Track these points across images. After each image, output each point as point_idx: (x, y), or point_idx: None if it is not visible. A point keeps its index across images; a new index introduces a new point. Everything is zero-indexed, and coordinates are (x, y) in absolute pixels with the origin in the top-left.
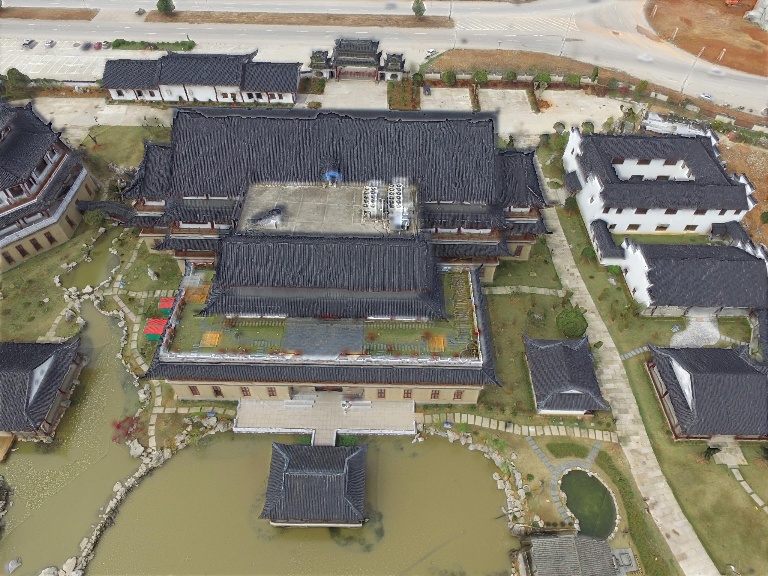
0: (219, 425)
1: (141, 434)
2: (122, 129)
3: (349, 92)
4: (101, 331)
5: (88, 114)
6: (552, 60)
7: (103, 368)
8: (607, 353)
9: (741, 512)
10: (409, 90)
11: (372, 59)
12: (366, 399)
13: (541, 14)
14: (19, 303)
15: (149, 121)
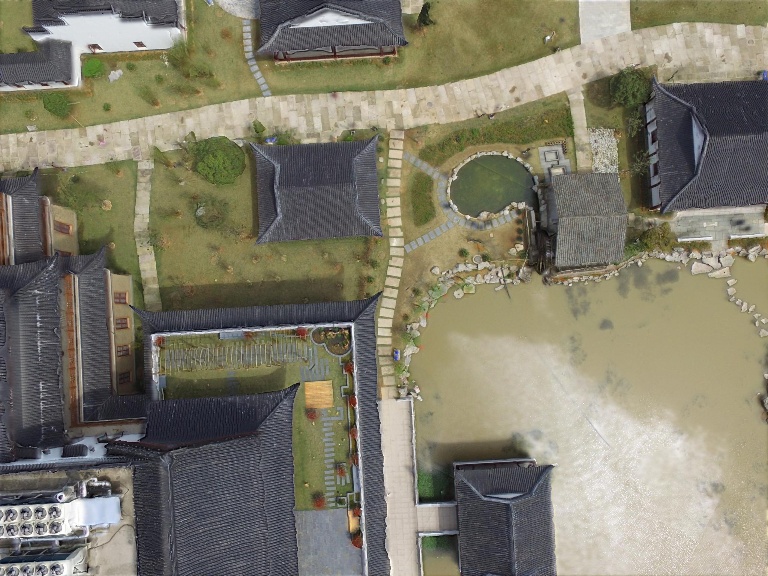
0: None
1: None
2: None
3: None
4: None
5: None
6: None
7: None
8: (260, 115)
9: (483, 5)
10: None
11: None
12: None
13: None
14: None
15: None
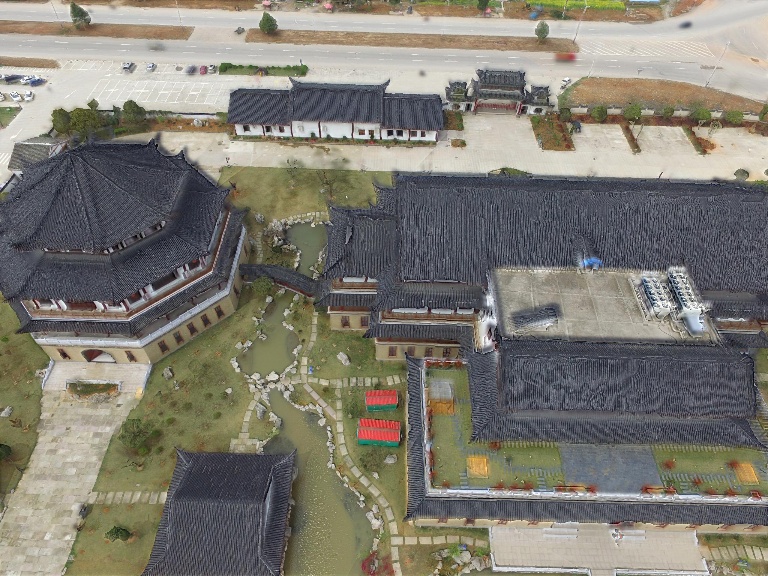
0: (474, 562)
1: (387, 575)
2: (256, 171)
3: (491, 128)
4: (300, 431)
5: (213, 152)
6: (698, 91)
7: (317, 482)
8: None
9: None
10: (556, 126)
11: (518, 92)
12: (640, 528)
13: (667, 37)
14: (199, 394)
15: (282, 161)
